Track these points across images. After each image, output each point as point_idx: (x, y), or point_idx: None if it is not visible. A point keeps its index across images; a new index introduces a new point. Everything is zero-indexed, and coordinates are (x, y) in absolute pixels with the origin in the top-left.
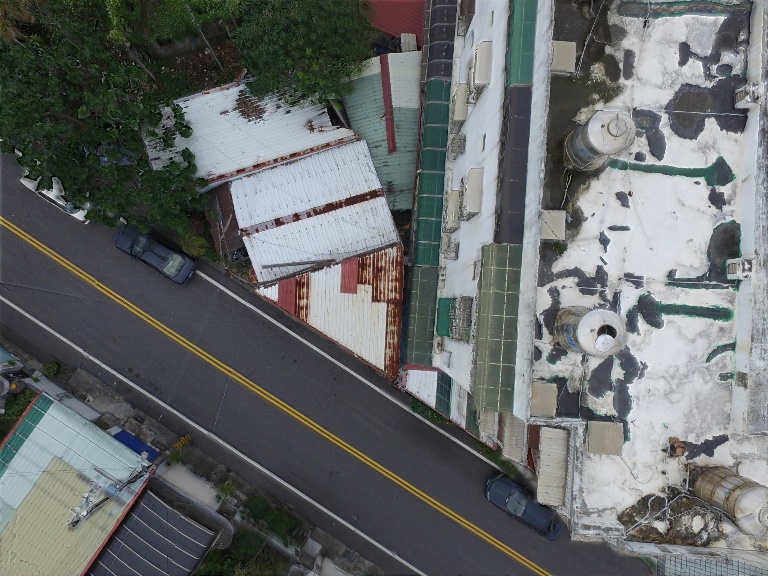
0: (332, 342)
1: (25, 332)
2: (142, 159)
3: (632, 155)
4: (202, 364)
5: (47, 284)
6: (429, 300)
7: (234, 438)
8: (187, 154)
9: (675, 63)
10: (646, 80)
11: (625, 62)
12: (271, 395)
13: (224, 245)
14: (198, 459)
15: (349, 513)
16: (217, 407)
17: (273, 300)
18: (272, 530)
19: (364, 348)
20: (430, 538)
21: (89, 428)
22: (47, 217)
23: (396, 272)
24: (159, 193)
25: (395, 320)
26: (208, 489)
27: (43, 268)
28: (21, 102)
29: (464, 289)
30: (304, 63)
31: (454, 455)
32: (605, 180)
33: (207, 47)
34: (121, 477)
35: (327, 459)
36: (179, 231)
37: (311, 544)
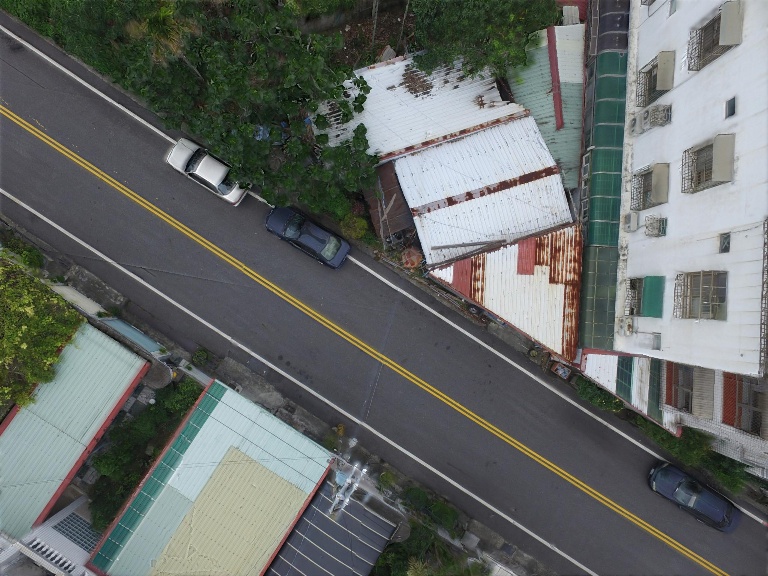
0: (485, 328)
1: (170, 319)
2: (323, 134)
3: None
4: (354, 351)
5: (192, 269)
6: (608, 281)
7: (388, 428)
8: (361, 130)
9: None
10: None
11: None
12: (425, 383)
13: (385, 226)
14: (350, 450)
15: (507, 505)
16: (370, 396)
17: (448, 282)
18: (436, 523)
19: (541, 332)
20: (591, 530)
21: (264, 416)
22: (192, 200)
23: (575, 252)
24: (338, 170)
25: (573, 302)
26: (363, 481)
27: (188, 253)
28: (233, 69)
29: (692, 264)
30: (502, 31)
31: (613, 444)
32: None
33: (347, 24)
34: (298, 467)
35: (483, 449)
36: (338, 212)
37: (468, 537)
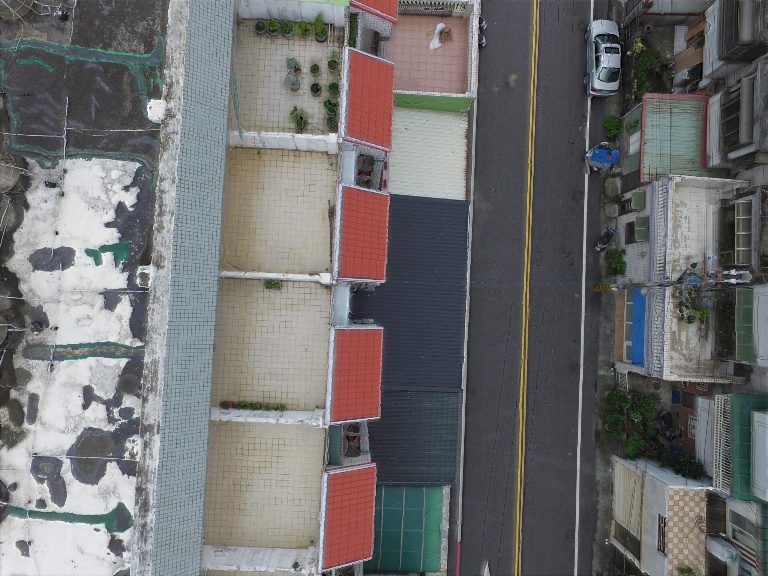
0: None
1: None
2: None
3: (33, 503)
4: None
5: None
6: None
7: None
8: None
9: (79, 406)
10: (49, 425)
11: (29, 406)
12: None
13: None
14: None
15: None
16: None
17: None
18: None
19: None
20: None
21: None
22: None
23: None
24: None
25: None
26: None
27: None
28: None
29: None
30: None
31: None
32: (5, 529)
33: None
34: None
35: None
36: None
37: None
